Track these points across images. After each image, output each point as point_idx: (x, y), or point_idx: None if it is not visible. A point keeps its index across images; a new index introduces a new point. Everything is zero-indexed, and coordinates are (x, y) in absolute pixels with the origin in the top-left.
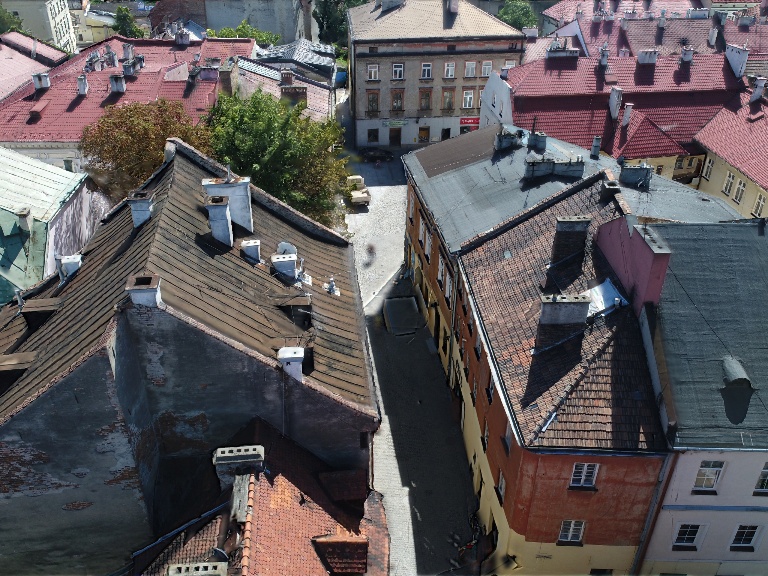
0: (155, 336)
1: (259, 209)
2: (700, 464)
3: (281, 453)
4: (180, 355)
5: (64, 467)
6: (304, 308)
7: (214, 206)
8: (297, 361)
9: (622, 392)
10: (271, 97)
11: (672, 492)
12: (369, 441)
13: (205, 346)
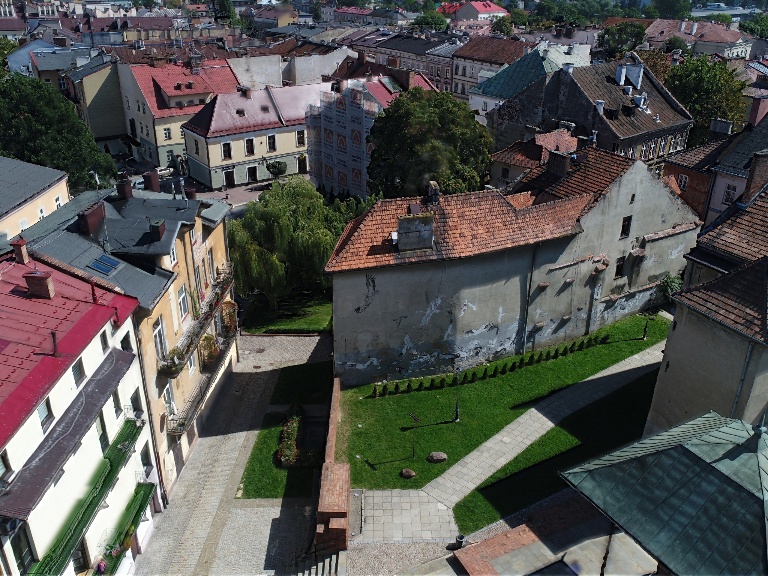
0: (565, 83)
1: (654, 89)
2: (727, 186)
3: None
4: (569, 93)
5: (525, 116)
6: (629, 108)
7: (619, 65)
8: (601, 104)
9: (714, 153)
10: (750, 80)
11: (714, 200)
12: (616, 149)
13: (577, 91)
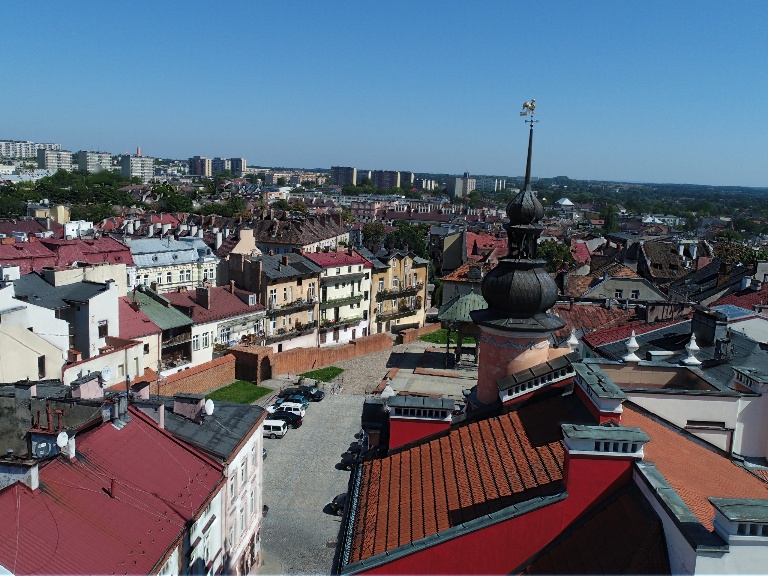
0: None
1: None
2: None
3: None
4: None
5: None
6: None
7: None
8: None
9: None
10: None
11: None
12: None
13: None
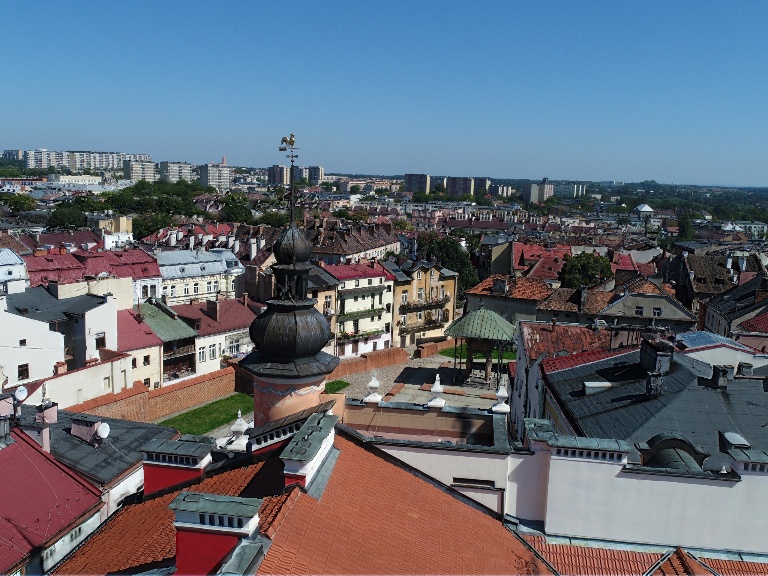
0: None
1: None
2: None
3: (682, 290)
4: None
5: None
6: None
7: None
8: None
9: None
10: None
11: None
12: None
13: None
